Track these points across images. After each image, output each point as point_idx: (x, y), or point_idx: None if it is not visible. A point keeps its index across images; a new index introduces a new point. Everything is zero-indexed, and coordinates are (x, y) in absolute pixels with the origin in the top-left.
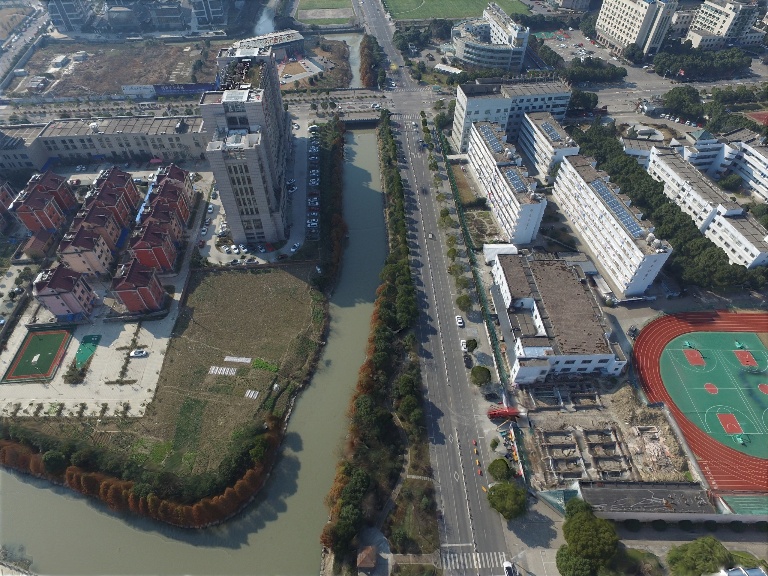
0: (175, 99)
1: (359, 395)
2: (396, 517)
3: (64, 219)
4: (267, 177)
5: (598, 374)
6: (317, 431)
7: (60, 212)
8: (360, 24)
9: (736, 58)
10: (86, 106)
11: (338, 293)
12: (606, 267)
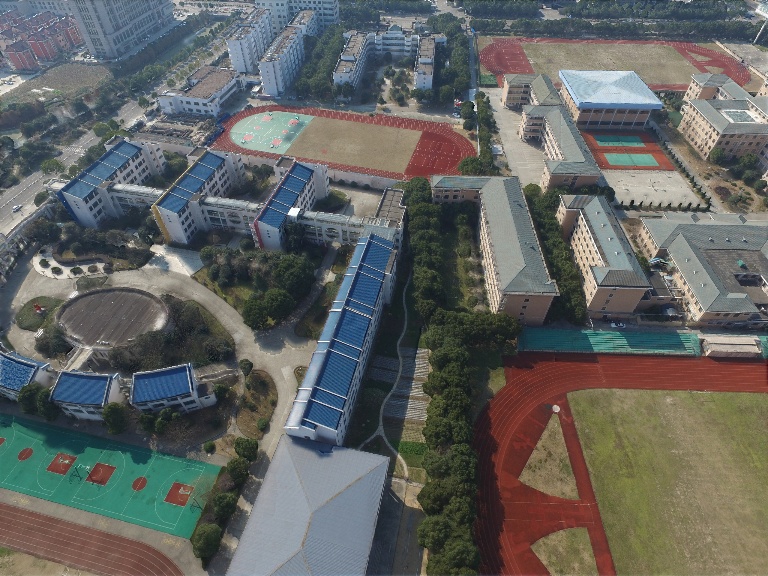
0: None
1: None
2: (61, 136)
3: None
4: (98, 10)
5: None
6: None
7: None
8: None
9: (524, 4)
10: None
11: None
12: None
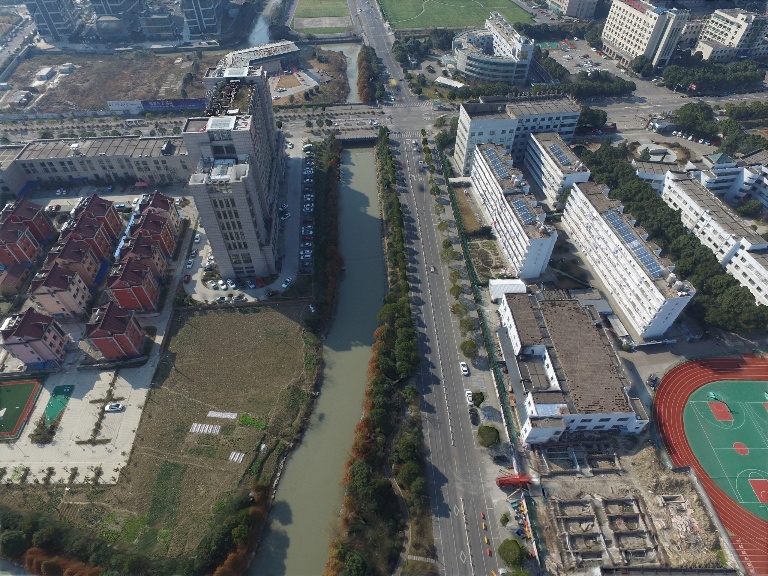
0: (163, 116)
1: (355, 461)
2: None
3: (40, 250)
4: (256, 210)
5: (617, 432)
6: (308, 500)
7: (36, 243)
8: (358, 33)
9: (749, 71)
10: (70, 123)
11: (333, 334)
12: (621, 306)
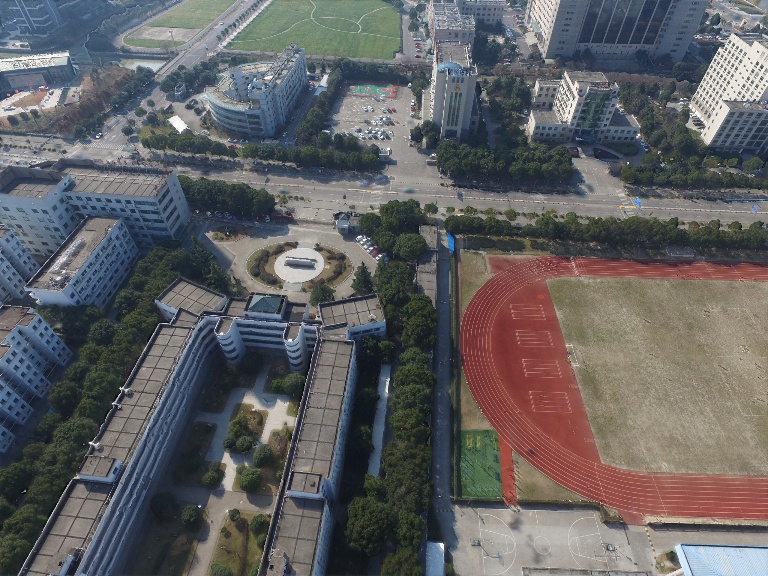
0: None
1: None
2: None
3: None
4: None
5: None
6: None
7: None
8: (179, 51)
9: (547, 163)
10: None
11: None
12: None
